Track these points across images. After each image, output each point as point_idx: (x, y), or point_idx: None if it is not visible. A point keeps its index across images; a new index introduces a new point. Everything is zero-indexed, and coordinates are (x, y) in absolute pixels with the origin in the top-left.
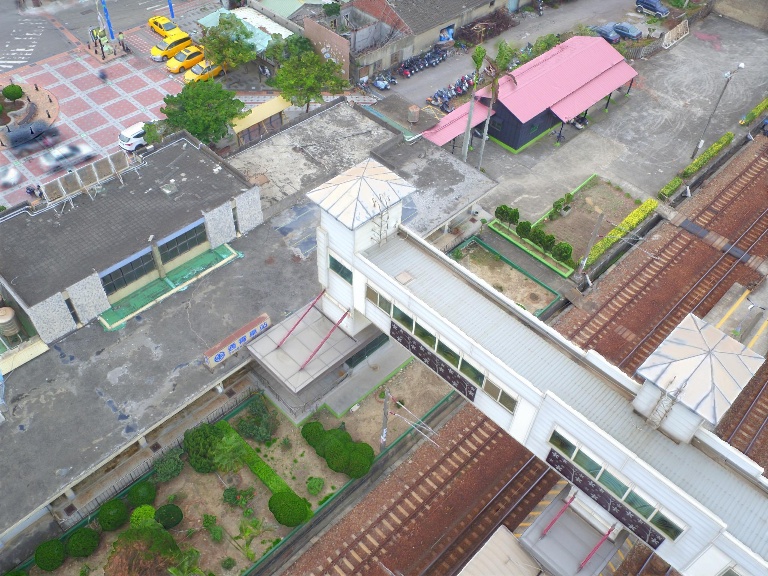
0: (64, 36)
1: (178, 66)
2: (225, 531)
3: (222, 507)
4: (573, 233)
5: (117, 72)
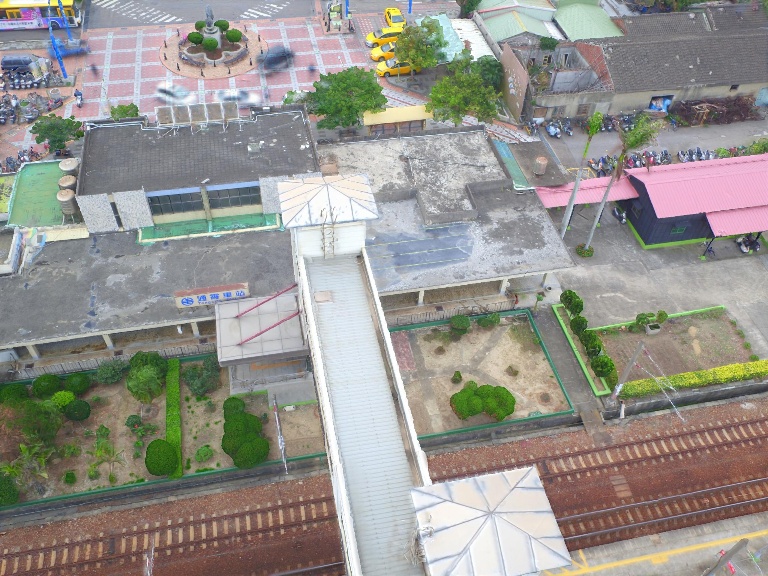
0: (314, 4)
1: (379, 55)
2: (113, 448)
3: (126, 428)
4: (644, 355)
5: (330, 45)
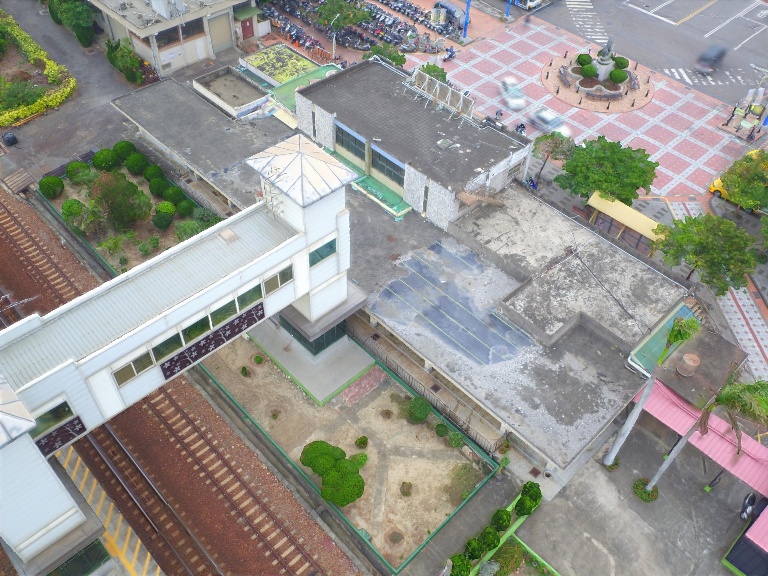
0: None
1: None
2: None
3: None
4: None
5: (707, 137)
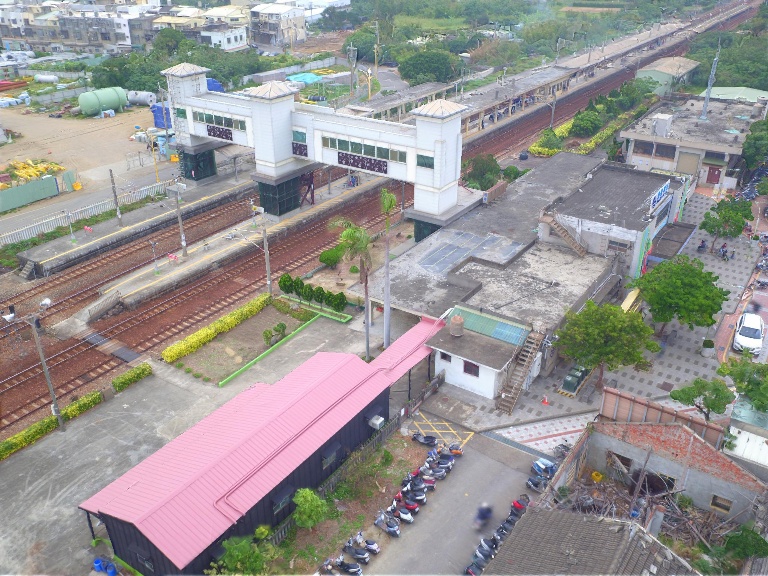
0: None
1: None
2: None
3: None
4: None
5: None
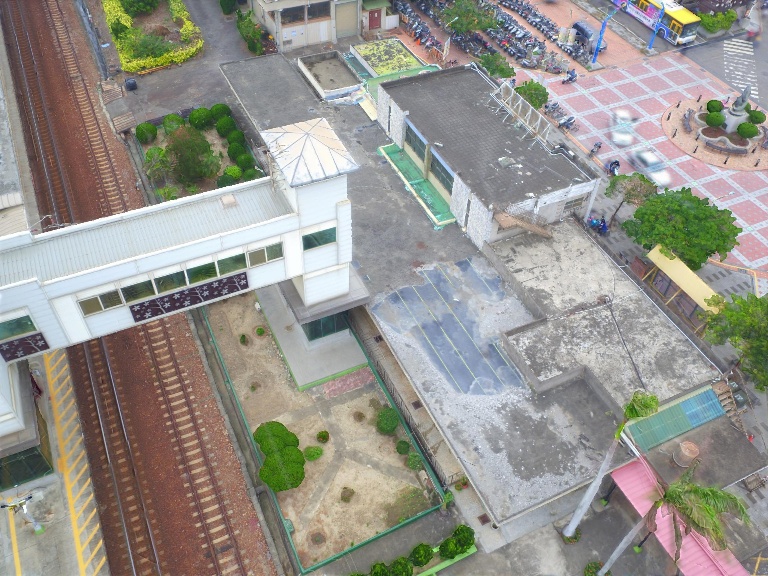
0: None
1: None
2: None
3: None
4: None
5: None
